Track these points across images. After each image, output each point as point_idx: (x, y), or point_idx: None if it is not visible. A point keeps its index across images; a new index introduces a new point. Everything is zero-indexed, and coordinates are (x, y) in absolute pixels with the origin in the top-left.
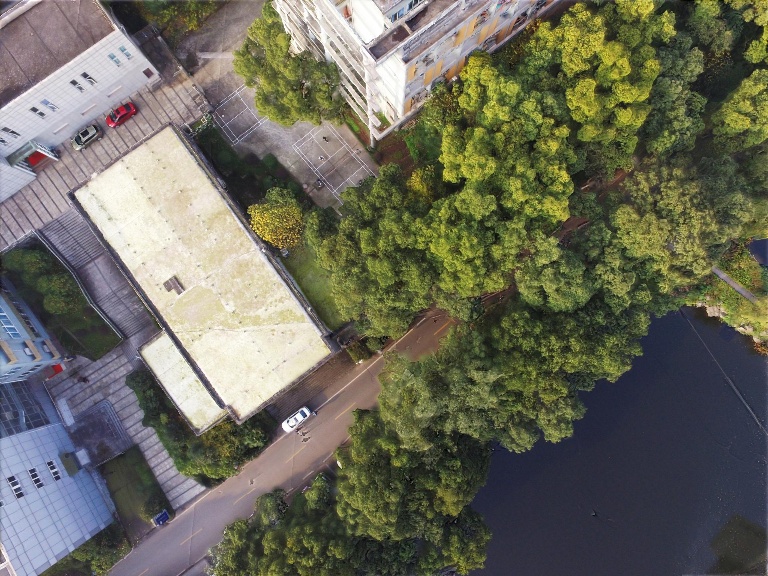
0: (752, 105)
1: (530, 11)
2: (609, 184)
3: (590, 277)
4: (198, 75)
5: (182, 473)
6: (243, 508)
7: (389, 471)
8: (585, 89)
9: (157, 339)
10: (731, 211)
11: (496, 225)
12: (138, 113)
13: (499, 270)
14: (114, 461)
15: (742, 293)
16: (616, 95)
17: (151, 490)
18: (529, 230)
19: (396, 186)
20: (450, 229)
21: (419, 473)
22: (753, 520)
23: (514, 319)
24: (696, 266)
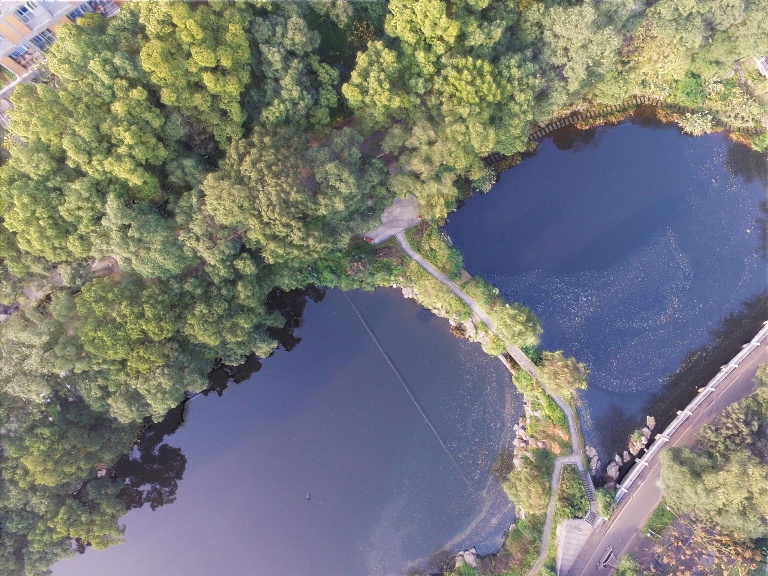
0: (363, 76)
1: None
2: (226, 153)
3: (177, 243)
4: None
5: None
6: None
7: None
8: (151, 50)
9: None
10: None
11: (62, 186)
12: None
13: (75, 233)
14: None
15: (435, 274)
16: (193, 58)
17: None
18: (104, 193)
19: None
20: None
21: (9, 440)
22: (438, 504)
23: (93, 284)
24: (294, 236)
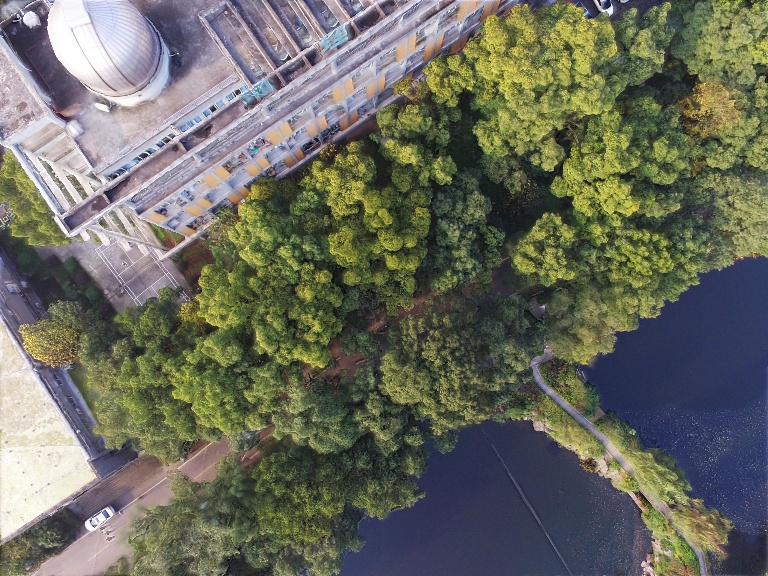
0: (538, 249)
1: (320, 139)
2: (393, 319)
3: (354, 421)
4: None
5: None
6: None
7: None
8: (342, 239)
9: None
10: (505, 360)
11: (249, 370)
12: None
13: (256, 412)
14: None
15: (568, 410)
16: (381, 243)
17: None
18: (287, 374)
19: (165, 316)
20: (194, 376)
21: None
22: None
23: (271, 461)
24: (467, 413)
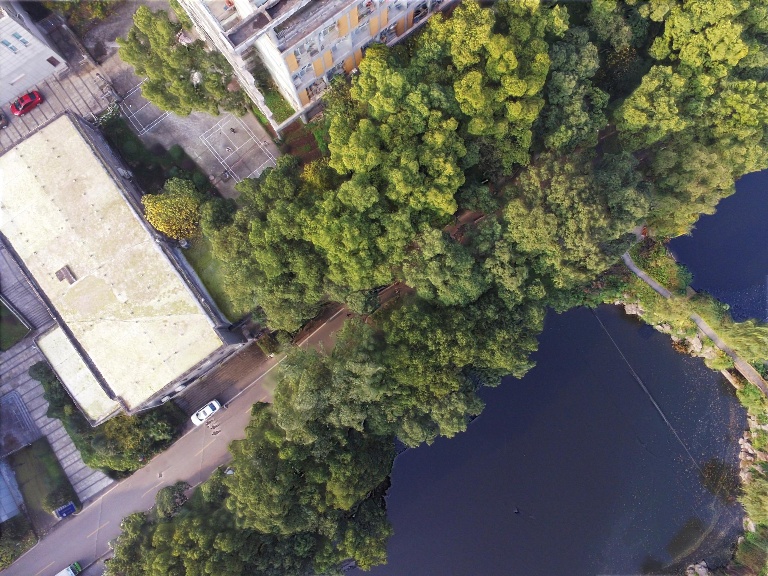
0: (649, 101)
1: (429, 4)
2: (507, 178)
3: (481, 271)
4: (106, 64)
5: (88, 465)
6: (151, 501)
7: (276, 464)
8: (471, 82)
9: (55, 329)
10: (624, 207)
11: (382, 217)
12: (44, 102)
13: (387, 263)
14: (23, 453)
15: (659, 291)
16: (505, 88)
17: (57, 482)
18: (417, 223)
19: (288, 177)
20: (332, 220)
21: (310, 466)
22: (667, 518)
23: (402, 312)
24: (589, 261)
